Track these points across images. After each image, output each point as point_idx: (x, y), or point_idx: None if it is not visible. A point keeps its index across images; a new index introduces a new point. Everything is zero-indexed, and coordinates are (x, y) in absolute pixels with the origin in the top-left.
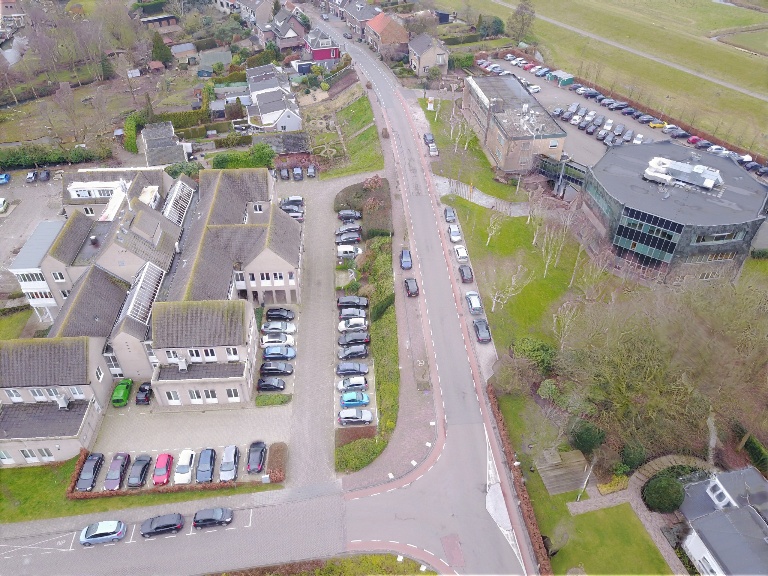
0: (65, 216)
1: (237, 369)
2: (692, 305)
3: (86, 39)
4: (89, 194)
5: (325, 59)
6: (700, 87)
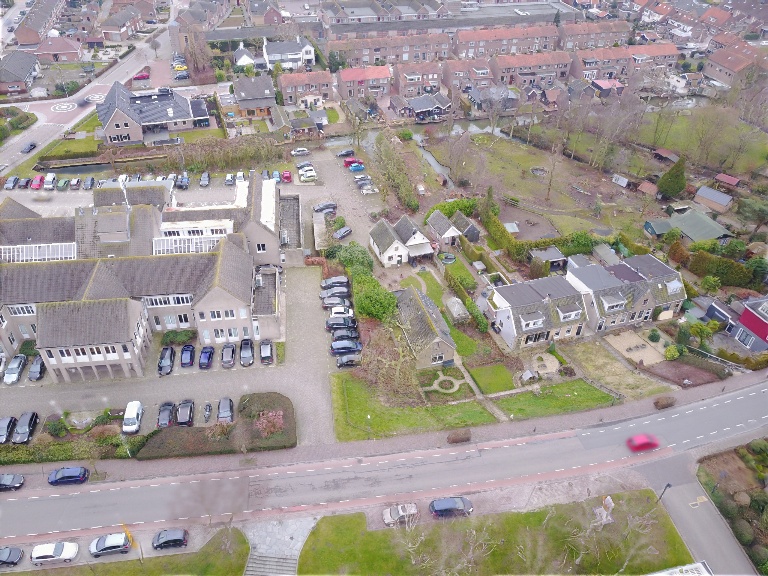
0: None
1: None
2: None
3: (605, 120)
4: None
5: (754, 332)
6: None
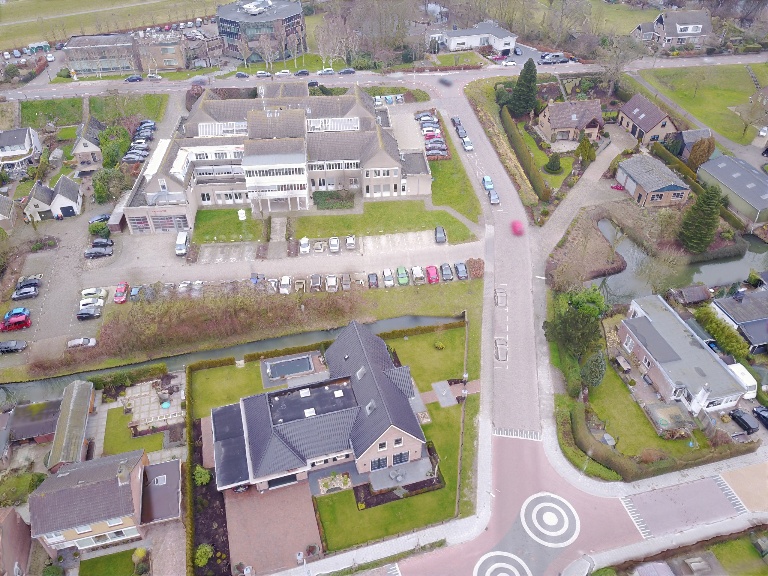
0: (187, 202)
1: (379, 113)
2: (369, 9)
3: None
4: None
5: None
6: (98, 16)
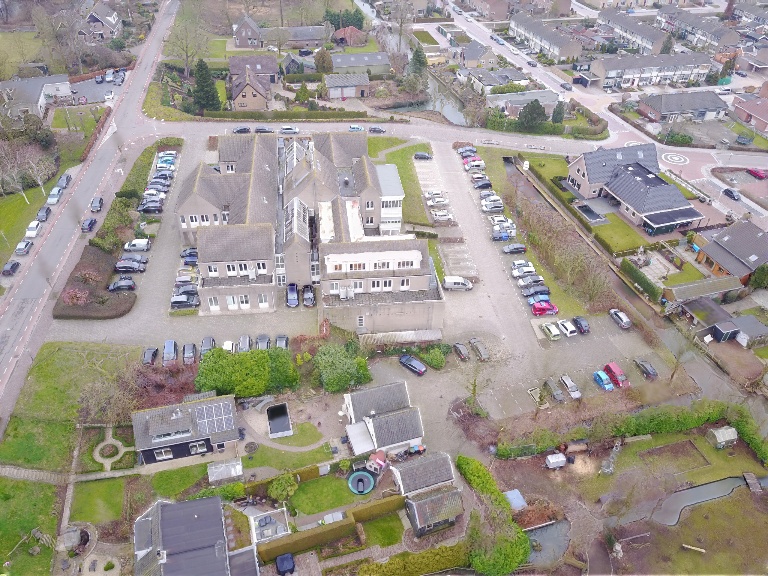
0: None
1: None
2: None
3: None
4: None
5: None
6: None
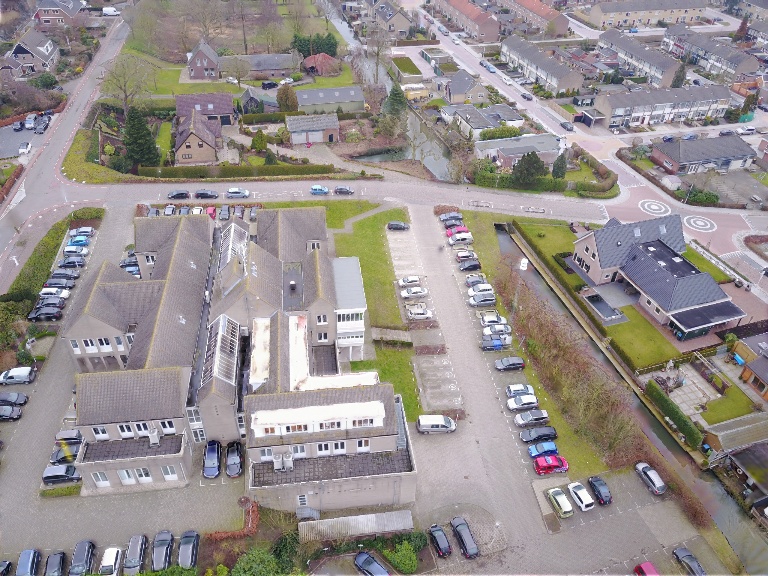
0: None
1: None
2: None
3: None
4: None
5: None
6: None
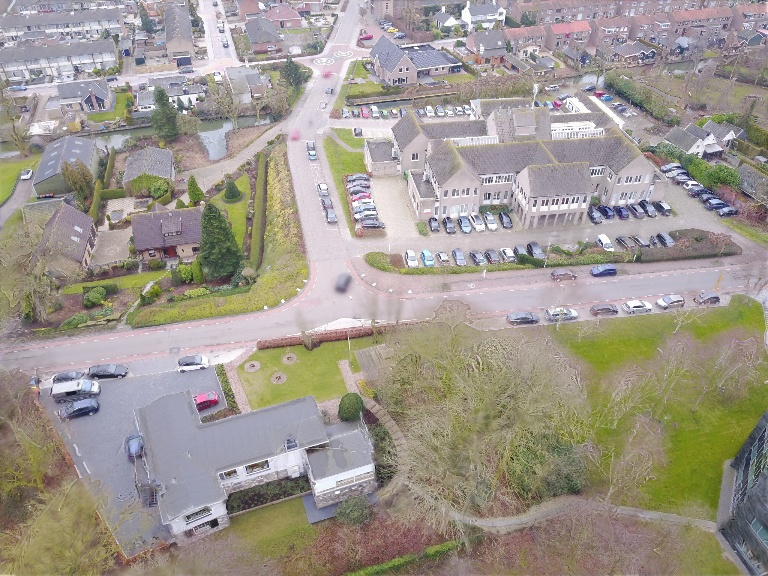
0: None
1: None
2: None
3: None
4: (572, 109)
5: None
6: None
